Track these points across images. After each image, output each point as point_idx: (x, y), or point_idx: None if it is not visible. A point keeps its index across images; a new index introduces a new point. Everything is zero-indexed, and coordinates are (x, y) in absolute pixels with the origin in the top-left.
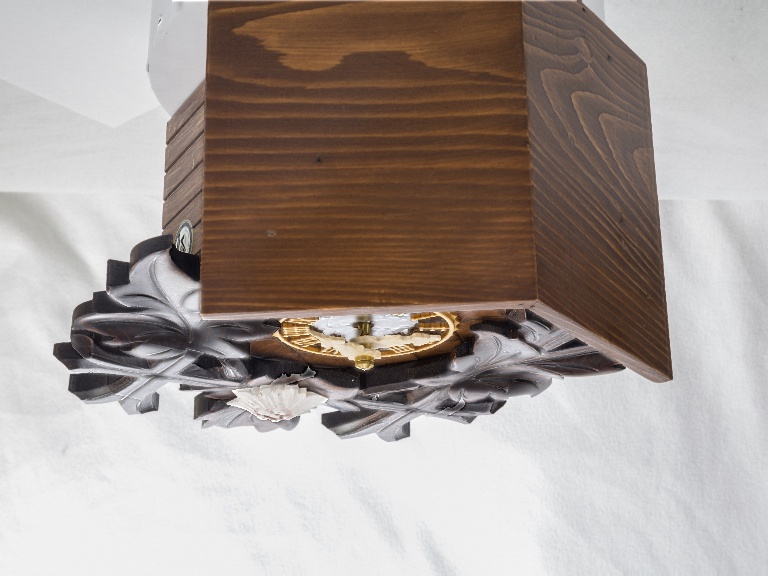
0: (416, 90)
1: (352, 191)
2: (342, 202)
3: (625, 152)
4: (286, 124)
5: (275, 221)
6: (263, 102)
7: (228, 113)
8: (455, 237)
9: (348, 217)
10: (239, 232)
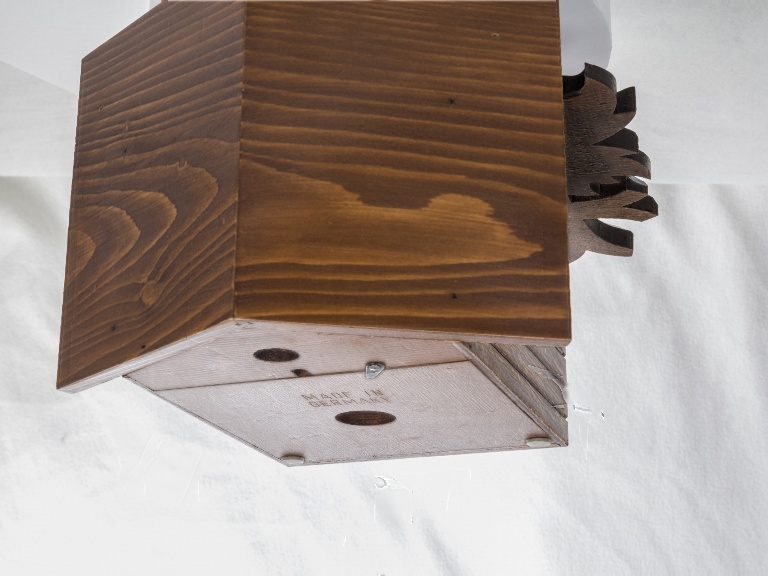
0: (354, 161)
1: (420, 66)
2: (429, 57)
3: (107, 237)
4: (485, 141)
5: (493, 47)
6: (508, 167)
7: (543, 159)
8: (322, 10)
9: (423, 42)
10: (526, 41)
